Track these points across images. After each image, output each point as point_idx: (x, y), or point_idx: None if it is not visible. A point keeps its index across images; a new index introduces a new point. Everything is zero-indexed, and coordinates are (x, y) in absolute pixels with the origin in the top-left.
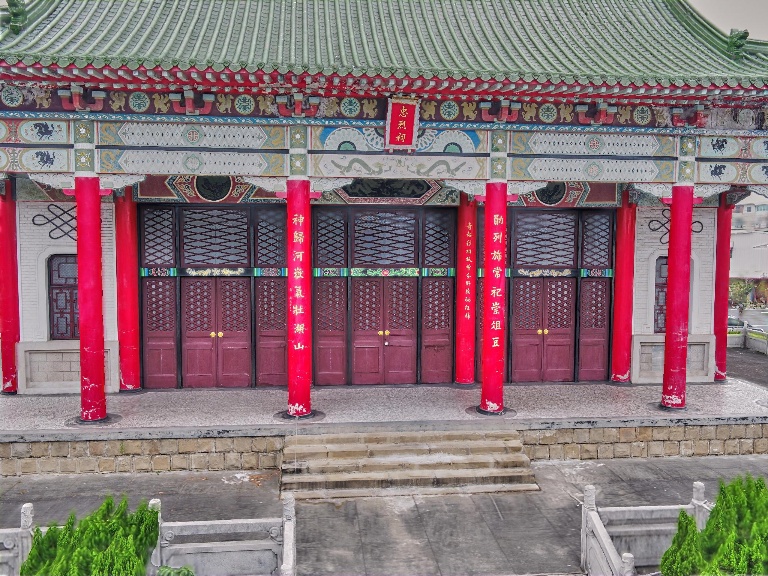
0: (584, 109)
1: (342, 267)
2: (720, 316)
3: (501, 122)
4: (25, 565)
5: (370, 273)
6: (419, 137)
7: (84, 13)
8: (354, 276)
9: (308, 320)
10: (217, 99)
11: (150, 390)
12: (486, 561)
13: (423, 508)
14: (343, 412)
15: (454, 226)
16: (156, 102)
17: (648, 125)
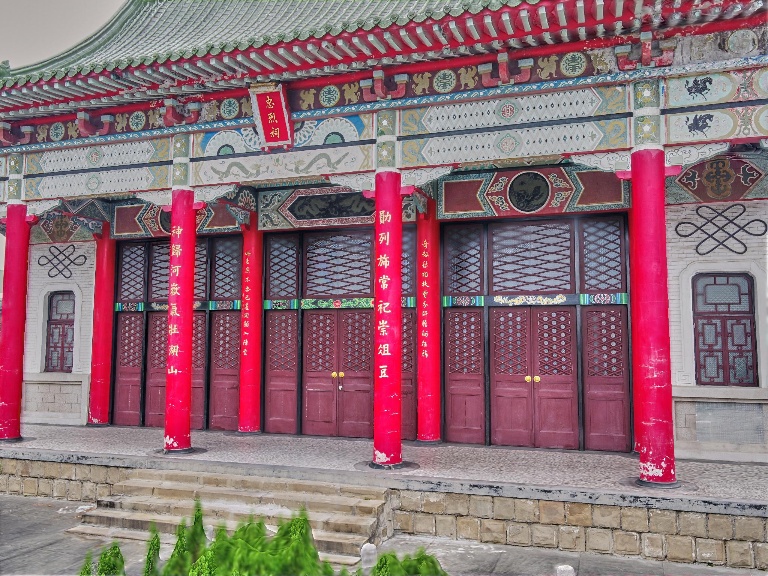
0: (487, 68)
1: (293, 298)
2: None
3: (385, 100)
4: None
5: (321, 304)
6: (298, 131)
7: None
8: (305, 308)
9: (185, 342)
10: (116, 119)
11: (115, 426)
12: None
13: None
14: (226, 452)
15: (414, 247)
16: (69, 130)
17: (582, 75)
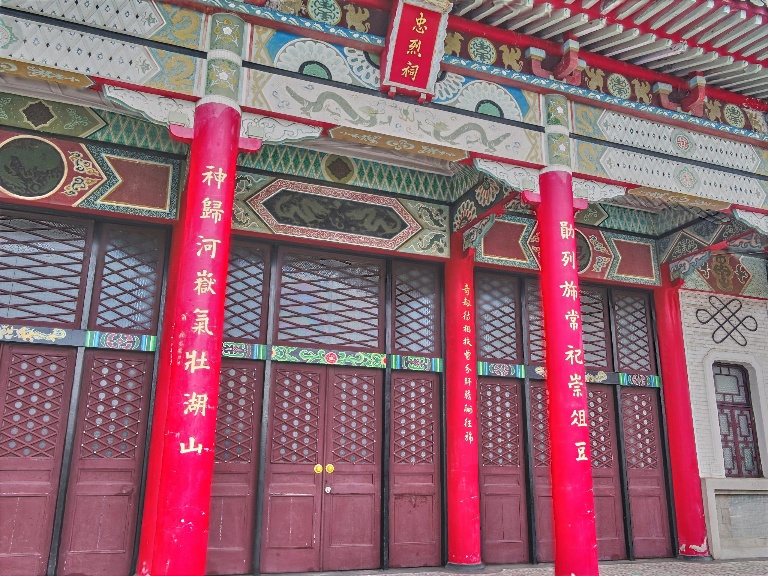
0: (668, 88)
1: (256, 342)
2: None
3: (560, 82)
4: None
5: (305, 356)
6: (437, 81)
7: None
8: (277, 360)
9: (216, 388)
10: None
11: None
12: None
13: None
14: None
15: (439, 292)
16: None
17: None
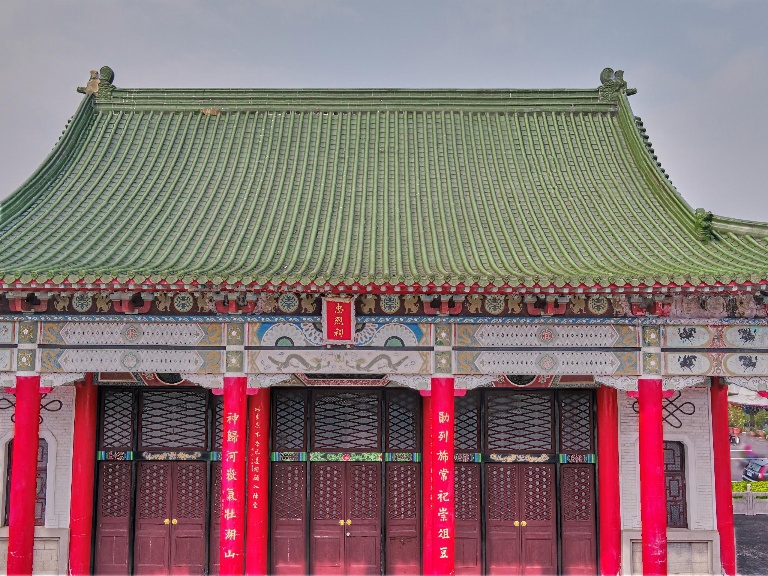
0: (532, 300)
1: (301, 451)
2: (723, 510)
3: (444, 315)
4: None
5: (330, 458)
6: (359, 331)
7: (56, 209)
8: (313, 461)
9: (241, 524)
10: (157, 297)
11: None
12: None
13: None
14: None
15: (419, 407)
16: (98, 302)
17: (605, 315)
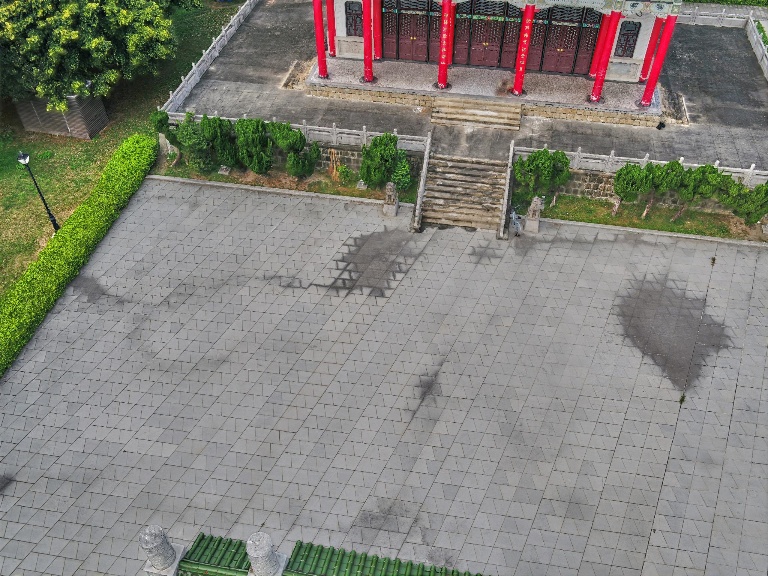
0: None
1: (469, 14)
2: (649, 52)
3: None
4: (371, 146)
5: (481, 18)
6: None
7: None
8: None
9: (447, 53)
10: None
11: (386, 59)
12: (483, 154)
13: (475, 132)
14: (459, 86)
15: None
16: None
17: None
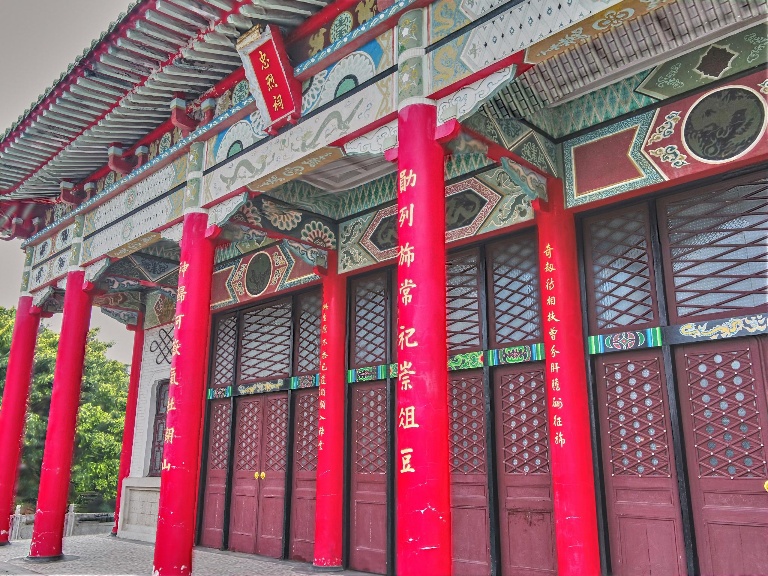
0: None
1: (380, 364)
2: None
3: None
4: None
5: None
6: (306, 92)
7: None
8: (394, 377)
9: (184, 422)
10: (149, 150)
11: (198, 548)
12: None
13: None
14: None
15: (539, 261)
16: (117, 176)
17: None
